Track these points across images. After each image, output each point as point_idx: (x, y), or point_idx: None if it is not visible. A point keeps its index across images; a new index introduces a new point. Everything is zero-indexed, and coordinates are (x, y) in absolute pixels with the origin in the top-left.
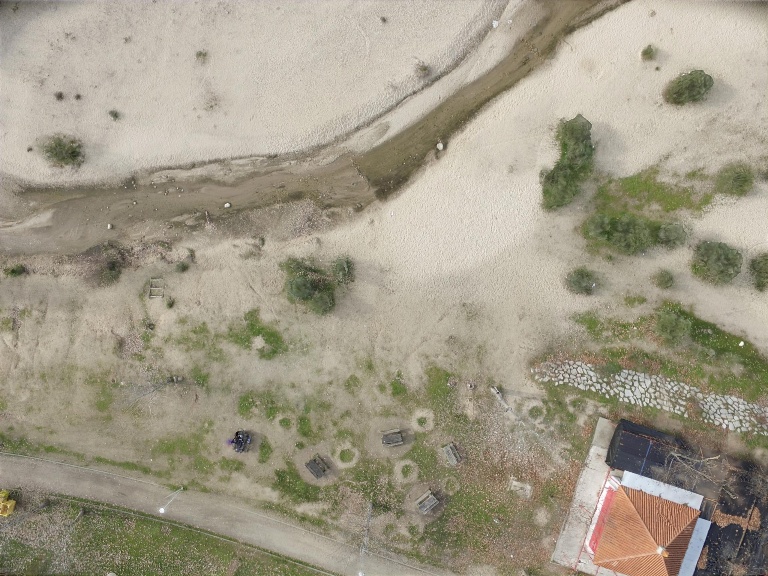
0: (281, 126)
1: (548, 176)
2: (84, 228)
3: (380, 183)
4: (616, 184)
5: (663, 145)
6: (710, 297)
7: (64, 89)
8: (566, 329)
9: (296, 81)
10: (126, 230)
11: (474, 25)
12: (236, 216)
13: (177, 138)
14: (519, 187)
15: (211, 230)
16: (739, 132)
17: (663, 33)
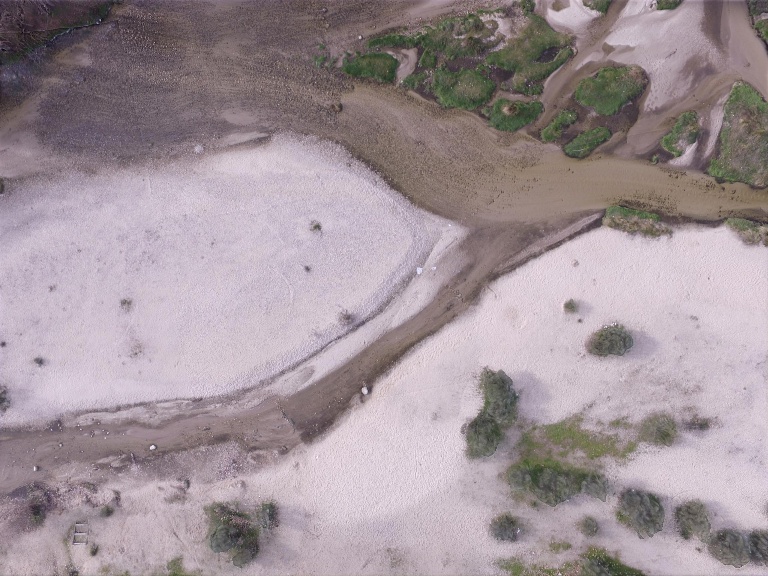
0: (205, 372)
1: (472, 424)
2: (10, 470)
3: (305, 426)
4: (540, 431)
5: (587, 394)
6: (635, 544)
7: None
8: (490, 575)
9: (220, 329)
10: (52, 472)
11: (398, 273)
12: (161, 458)
13: (102, 383)
14: (443, 434)
15: (137, 472)
16: (662, 383)
17: (586, 284)
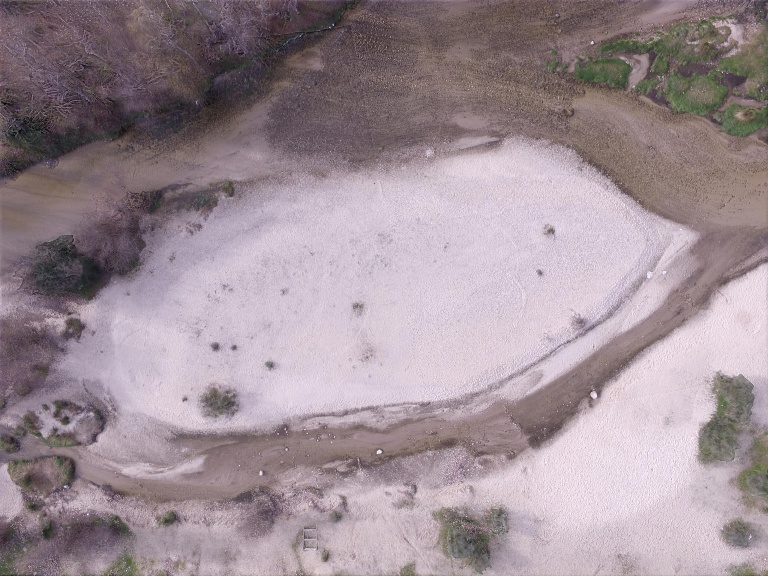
0: (436, 376)
1: (705, 429)
2: (235, 474)
3: (533, 430)
4: None
5: None
6: None
7: (220, 340)
8: None
9: (452, 332)
10: (277, 476)
11: (629, 277)
12: (388, 463)
13: (331, 387)
14: (675, 439)
15: (363, 477)
16: None
17: None
